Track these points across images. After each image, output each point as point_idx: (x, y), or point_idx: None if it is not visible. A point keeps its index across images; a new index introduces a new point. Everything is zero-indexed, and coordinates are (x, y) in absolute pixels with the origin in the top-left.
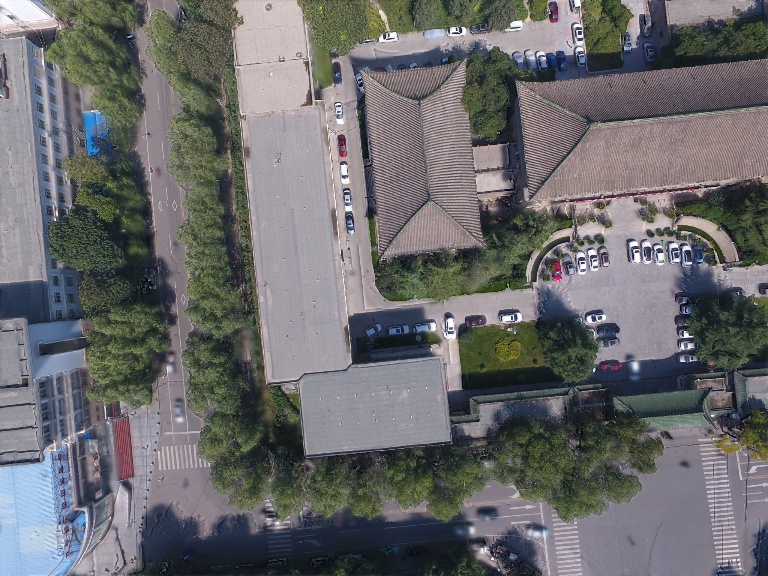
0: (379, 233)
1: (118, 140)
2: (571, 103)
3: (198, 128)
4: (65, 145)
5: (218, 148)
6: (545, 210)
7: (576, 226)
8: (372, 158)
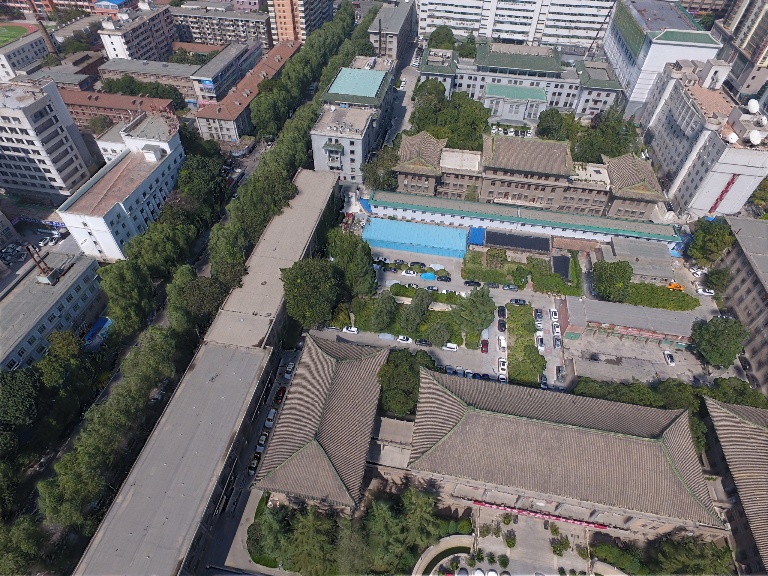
0: (262, 463)
1: (108, 339)
2: (461, 393)
3: (164, 337)
4: (67, 329)
5: (180, 368)
6: (449, 510)
7: (477, 535)
8: (287, 397)
